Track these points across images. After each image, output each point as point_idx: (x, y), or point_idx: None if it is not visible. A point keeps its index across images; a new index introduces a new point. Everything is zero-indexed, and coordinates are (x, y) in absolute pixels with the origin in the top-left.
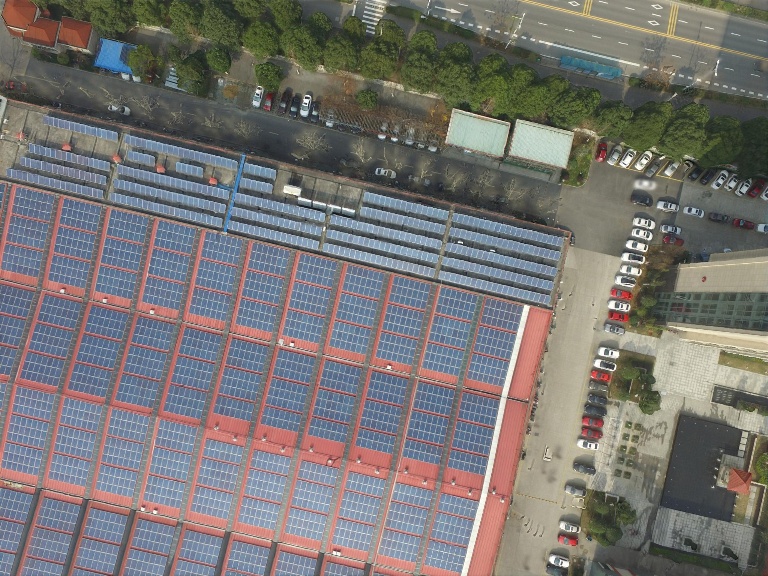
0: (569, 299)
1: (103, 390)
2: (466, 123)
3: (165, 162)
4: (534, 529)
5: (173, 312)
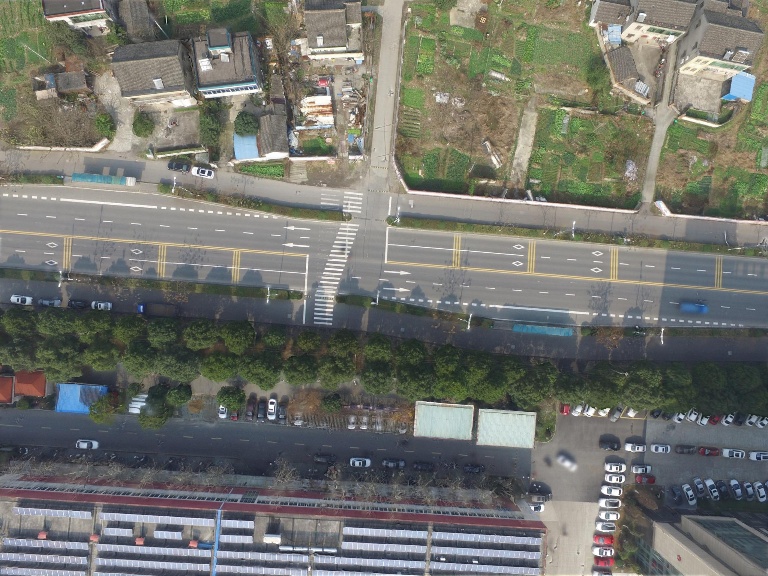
0: (555, 552)
1: None
2: (431, 413)
3: (142, 529)
4: None
5: None
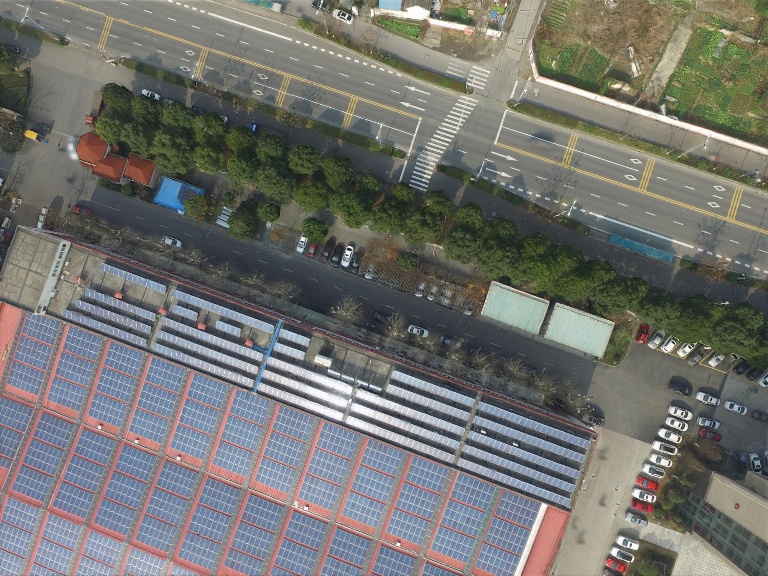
0: (592, 480)
1: (125, 528)
2: (504, 297)
3: (206, 317)
4: None
5: (198, 461)
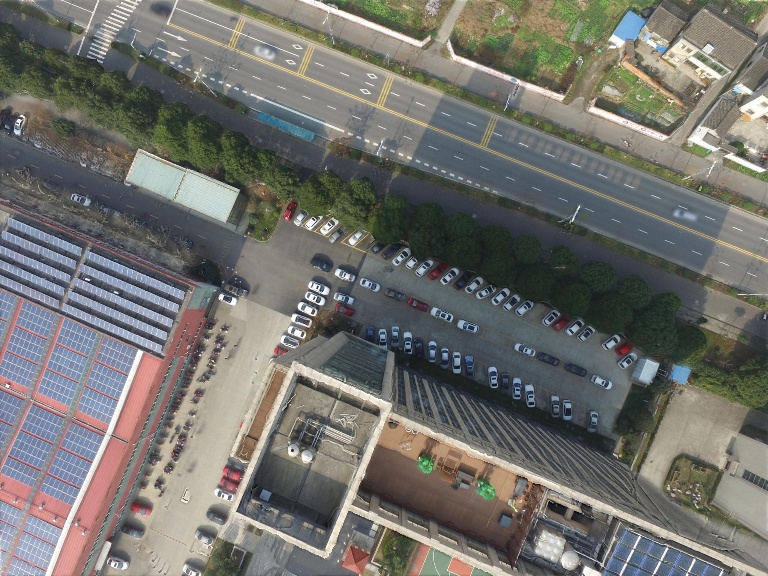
0: (234, 349)
1: None
2: (148, 164)
3: None
4: (160, 566)
5: None
